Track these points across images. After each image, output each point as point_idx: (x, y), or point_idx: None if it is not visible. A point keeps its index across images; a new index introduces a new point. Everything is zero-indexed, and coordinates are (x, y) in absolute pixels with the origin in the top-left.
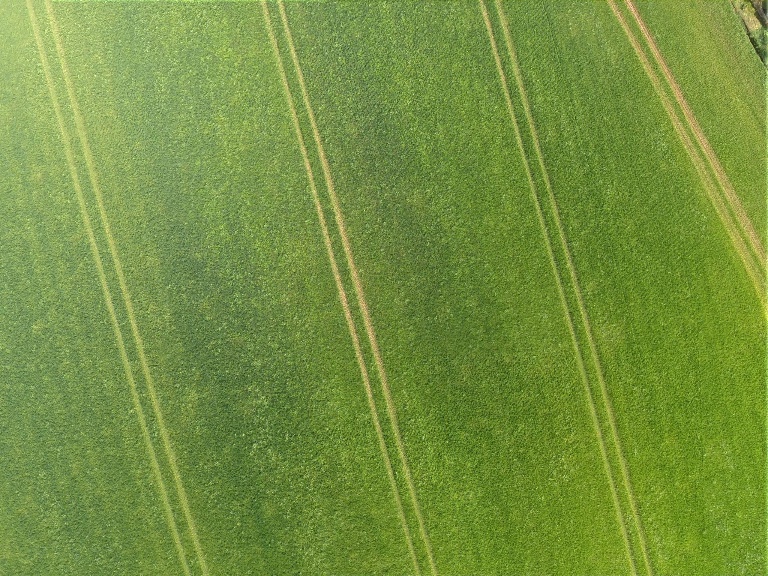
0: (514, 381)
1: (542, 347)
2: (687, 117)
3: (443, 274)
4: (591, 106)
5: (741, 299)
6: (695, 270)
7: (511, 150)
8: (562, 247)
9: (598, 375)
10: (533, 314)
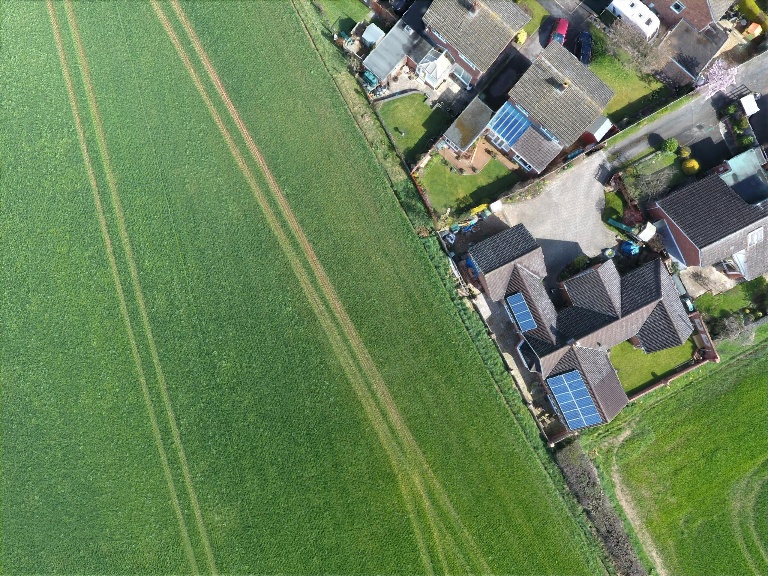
0: (112, 572)
1: (144, 534)
2: (320, 278)
3: (32, 458)
4: (207, 270)
5: (374, 475)
6: (322, 445)
7: (113, 321)
8: (169, 425)
9: (210, 562)
10: (134, 499)
